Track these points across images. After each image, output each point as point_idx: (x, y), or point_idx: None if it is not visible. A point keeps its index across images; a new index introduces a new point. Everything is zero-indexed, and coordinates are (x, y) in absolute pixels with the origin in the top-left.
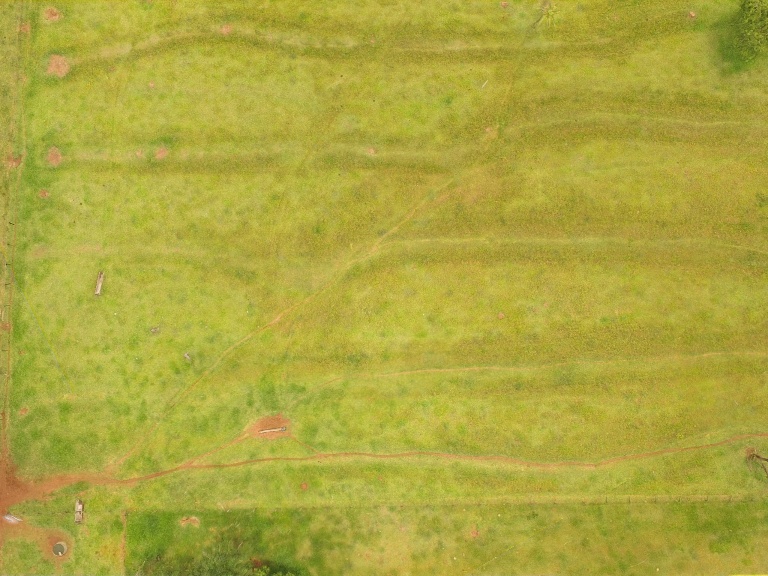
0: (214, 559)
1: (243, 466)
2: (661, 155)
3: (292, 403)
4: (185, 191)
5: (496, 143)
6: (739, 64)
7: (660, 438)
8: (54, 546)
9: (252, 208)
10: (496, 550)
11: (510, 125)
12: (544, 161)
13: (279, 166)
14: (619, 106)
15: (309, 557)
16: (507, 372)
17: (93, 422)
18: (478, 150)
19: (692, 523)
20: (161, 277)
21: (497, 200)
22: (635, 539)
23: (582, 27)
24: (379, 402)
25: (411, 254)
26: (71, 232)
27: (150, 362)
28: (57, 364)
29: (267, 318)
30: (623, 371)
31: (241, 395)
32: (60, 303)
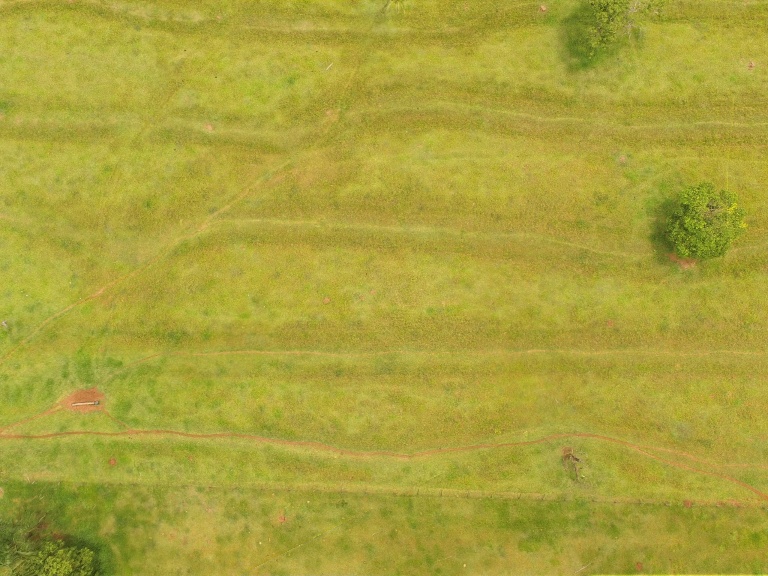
0: None
1: (52, 438)
2: (501, 148)
3: (108, 377)
4: (17, 157)
5: (336, 127)
6: (584, 60)
7: (478, 433)
8: None
9: (83, 178)
10: (303, 537)
11: (351, 109)
12: (383, 147)
13: (114, 137)
14: (463, 96)
15: (112, 534)
16: (328, 358)
17: None
18: (317, 132)
19: (502, 520)
20: None
21: (332, 184)
22: (444, 533)
23: (432, 15)
24: (196, 381)
25: (241, 233)
26: None
27: None
28: None
29: (90, 290)
30: (446, 363)
31: (56, 366)
32: None
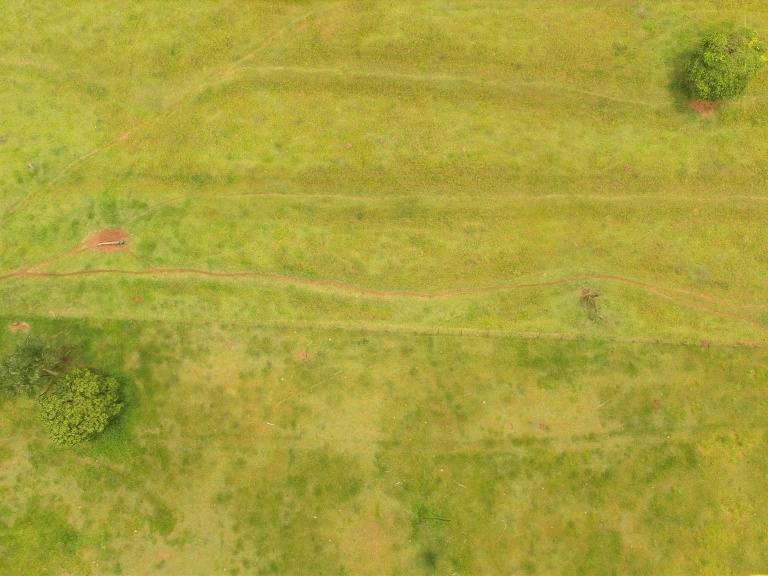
0: (22, 343)
1: (78, 276)
2: None
3: (132, 218)
4: (43, 6)
5: None
6: None
7: (497, 274)
8: None
9: (109, 26)
10: (324, 374)
11: None
12: None
13: None
14: None
15: (137, 369)
16: (350, 201)
17: None
18: None
19: (522, 358)
20: (12, 88)
21: (354, 34)
22: (464, 371)
23: None
24: (220, 222)
25: (264, 81)
26: None
27: None
28: None
29: (115, 134)
30: (466, 207)
31: (82, 207)
32: None
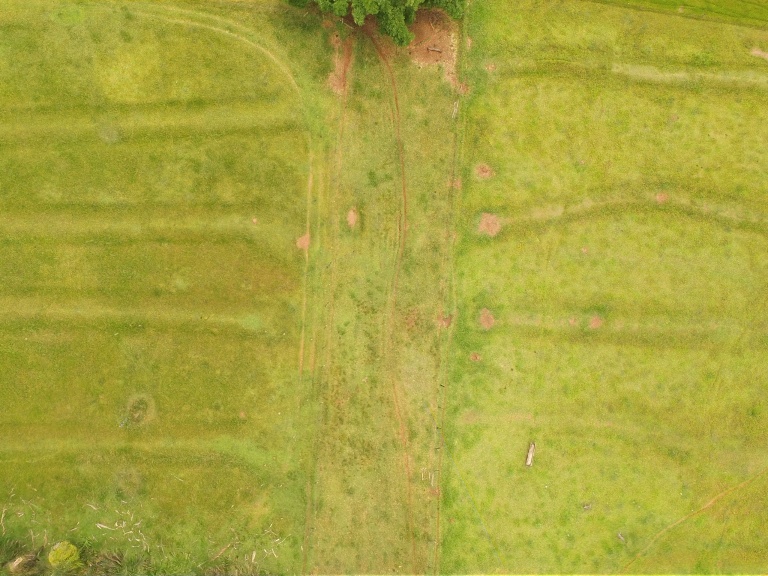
0: None
1: None
2: None
3: None
4: (617, 363)
5: None
6: None
7: None
8: None
9: (686, 385)
10: None
11: None
12: None
13: (714, 343)
14: None
15: None
16: None
17: None
18: None
19: None
20: (592, 451)
21: None
22: None
23: None
24: None
25: None
26: (501, 398)
27: (581, 539)
28: (487, 535)
29: (701, 502)
30: None
31: None
32: (490, 471)
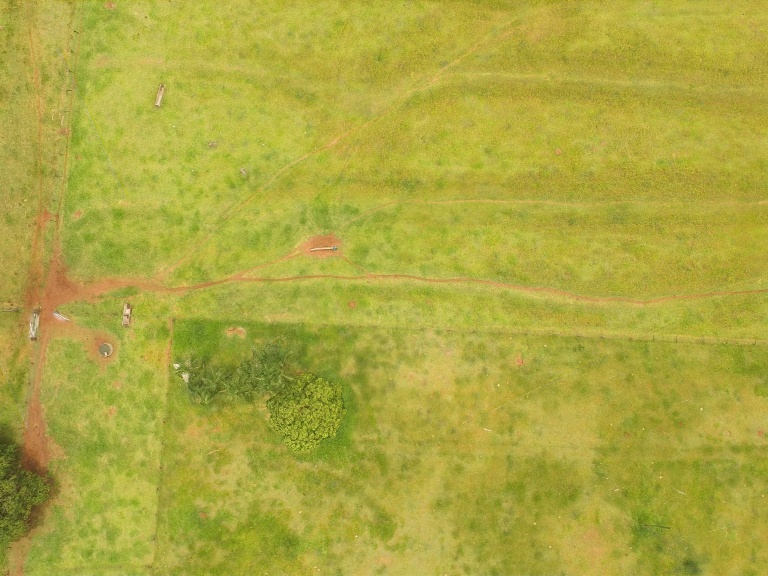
0: (265, 348)
1: (292, 281)
2: (727, 5)
3: (344, 224)
4: (250, 12)
5: None
6: None
7: (711, 281)
8: (100, 346)
9: (315, 32)
10: (540, 380)
11: None
12: (609, 4)
13: None
14: None
15: (353, 374)
16: (561, 207)
17: (146, 229)
18: None
19: (739, 365)
20: (221, 94)
21: (560, 39)
22: (680, 378)
23: None
24: (431, 228)
25: (471, 87)
26: (134, 44)
27: (205, 175)
28: (113, 171)
29: (324, 140)
30: (677, 214)
31: (294, 212)
32: (120, 112)
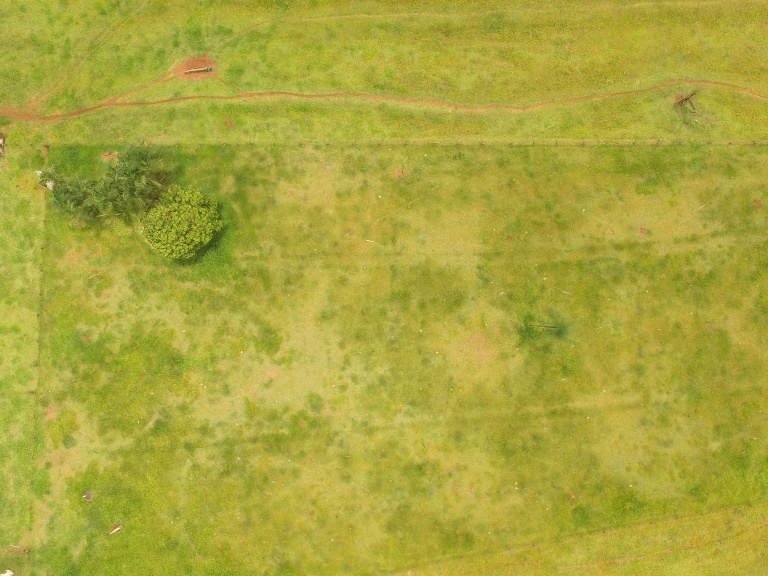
0: (127, 149)
1: (167, 103)
2: None
3: (219, 45)
4: None
5: None
6: None
7: (589, 84)
8: None
9: None
10: (421, 189)
11: None
12: None
13: None
14: None
15: (232, 193)
16: (437, 18)
17: (16, 59)
18: None
19: (619, 165)
20: None
21: None
22: (562, 181)
23: None
24: (307, 45)
25: None
26: None
27: (75, 3)
28: None
29: None
30: (554, 20)
31: (167, 35)
32: None
